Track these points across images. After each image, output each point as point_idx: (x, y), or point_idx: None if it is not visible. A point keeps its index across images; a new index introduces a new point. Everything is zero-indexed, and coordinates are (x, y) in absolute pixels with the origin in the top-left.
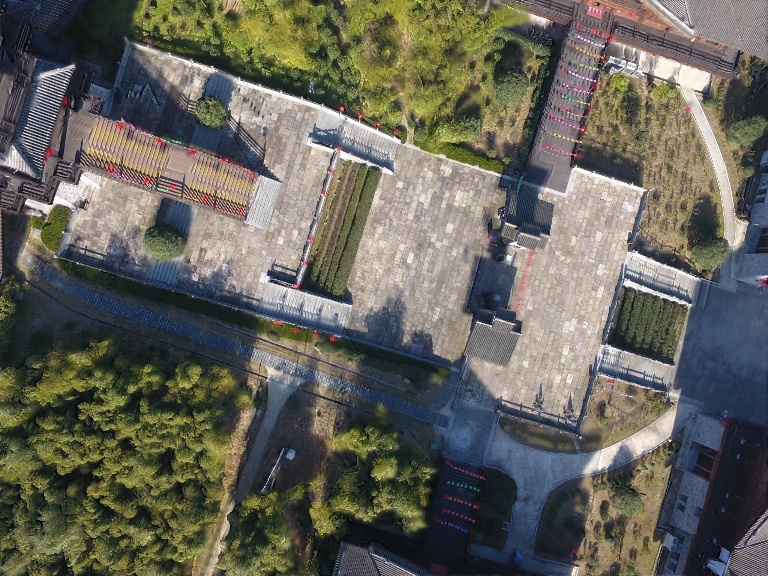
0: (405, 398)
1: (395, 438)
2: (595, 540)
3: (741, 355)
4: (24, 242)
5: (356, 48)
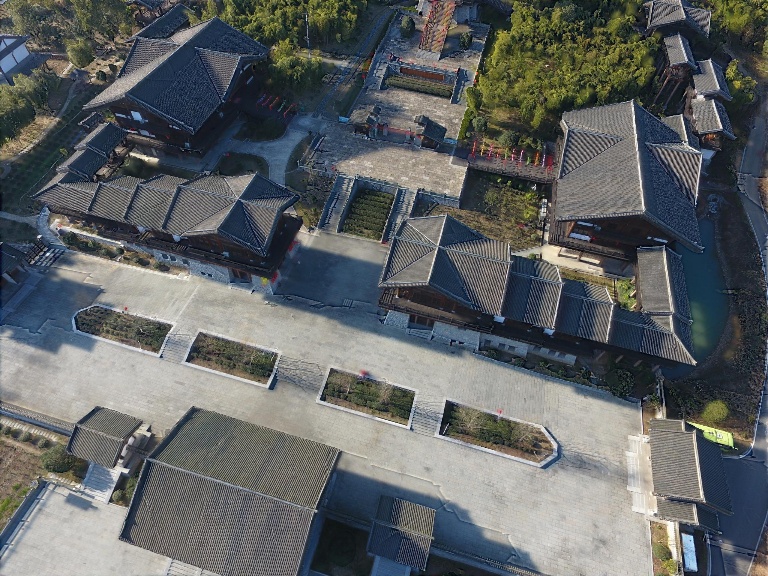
0: (330, 102)
1: (309, 97)
2: None
3: (343, 273)
4: (404, 6)
5: None
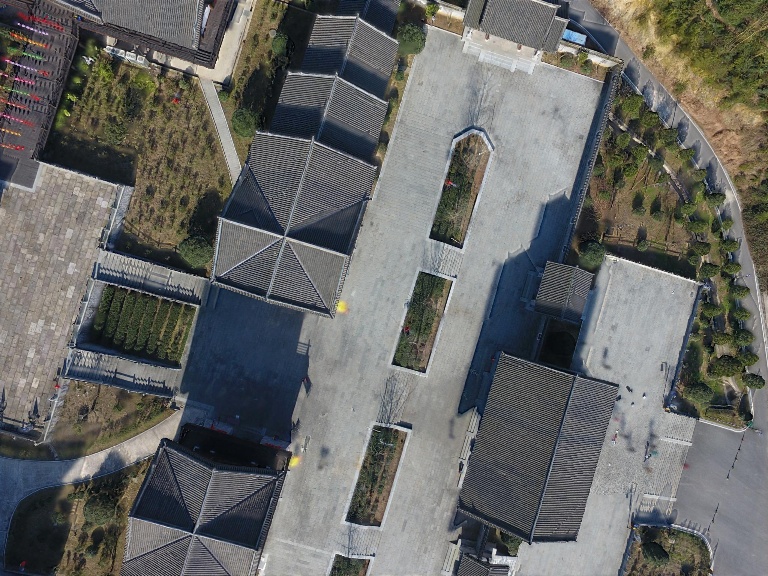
0: None
1: None
2: (81, 551)
3: (255, 357)
4: None
5: None
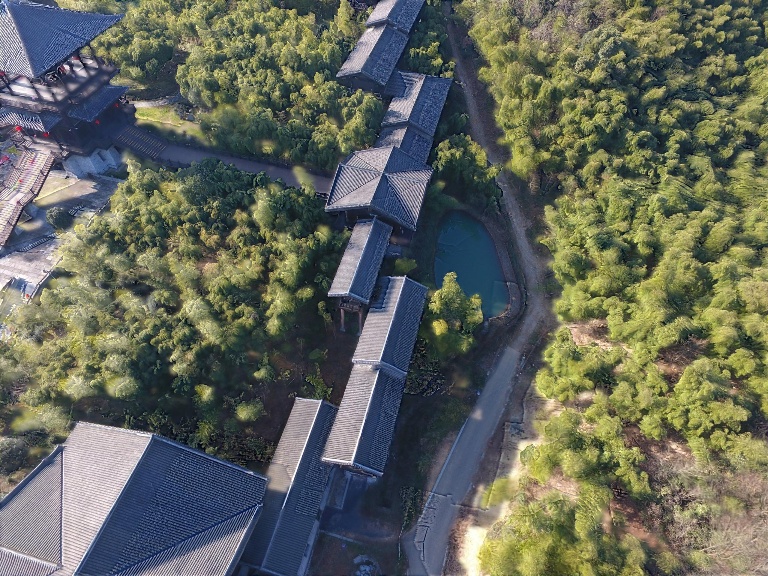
0: None
1: None
2: None
3: None
4: None
5: (47, 291)
